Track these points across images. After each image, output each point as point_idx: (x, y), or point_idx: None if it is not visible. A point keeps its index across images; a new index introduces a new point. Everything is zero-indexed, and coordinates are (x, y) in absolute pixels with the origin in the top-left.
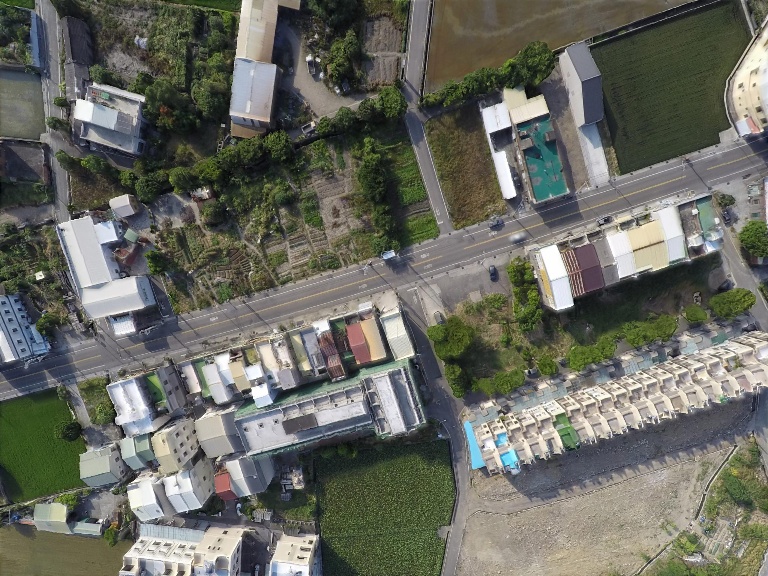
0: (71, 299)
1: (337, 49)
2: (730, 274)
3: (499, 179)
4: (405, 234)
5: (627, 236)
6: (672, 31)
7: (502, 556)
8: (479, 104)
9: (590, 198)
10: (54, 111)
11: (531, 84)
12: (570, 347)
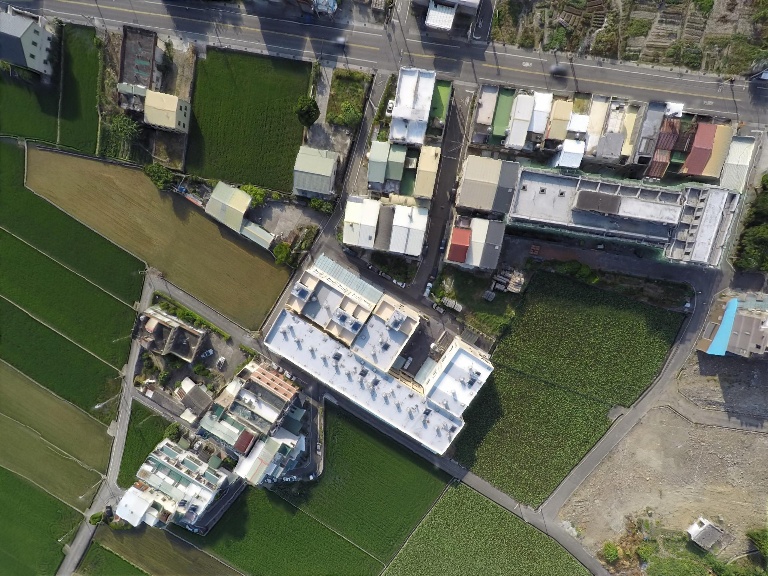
0: None
1: None
2: None
3: None
4: None
5: None
6: None
7: (661, 464)
8: None
9: None
10: None
11: None
12: None
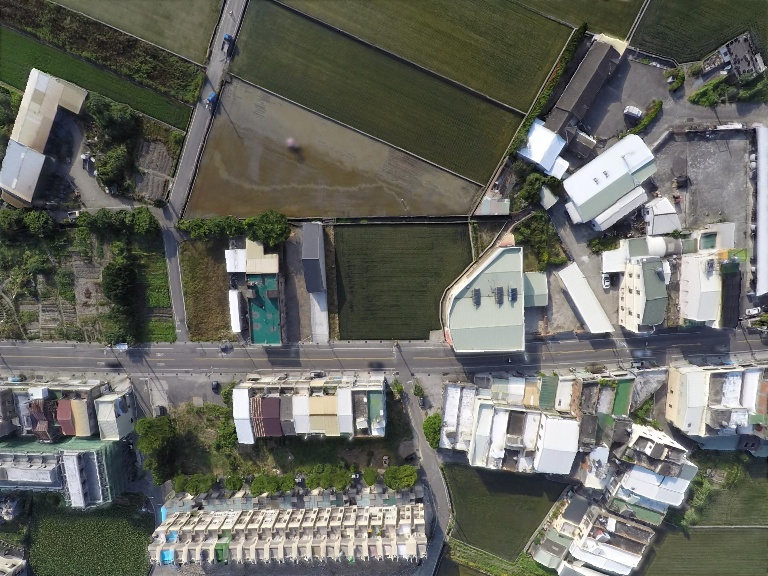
0: None
1: (109, 157)
2: (418, 449)
3: None
4: (145, 331)
5: (307, 401)
6: (407, 234)
7: None
8: (230, 242)
9: (310, 351)
10: None
11: (268, 244)
12: (272, 468)
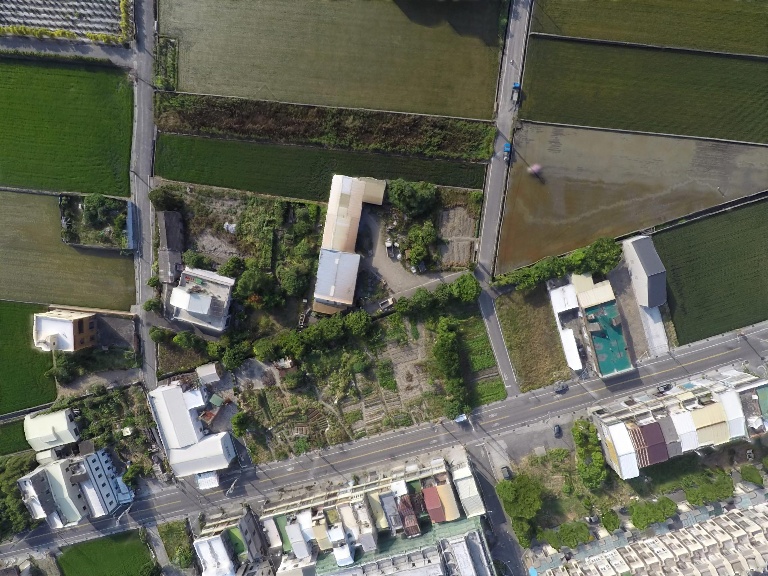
0: (155, 451)
1: (415, 237)
2: None
3: (565, 349)
4: (475, 397)
5: (691, 417)
6: (728, 221)
7: None
8: (547, 283)
9: (650, 366)
10: (145, 286)
11: (598, 272)
12: (629, 497)
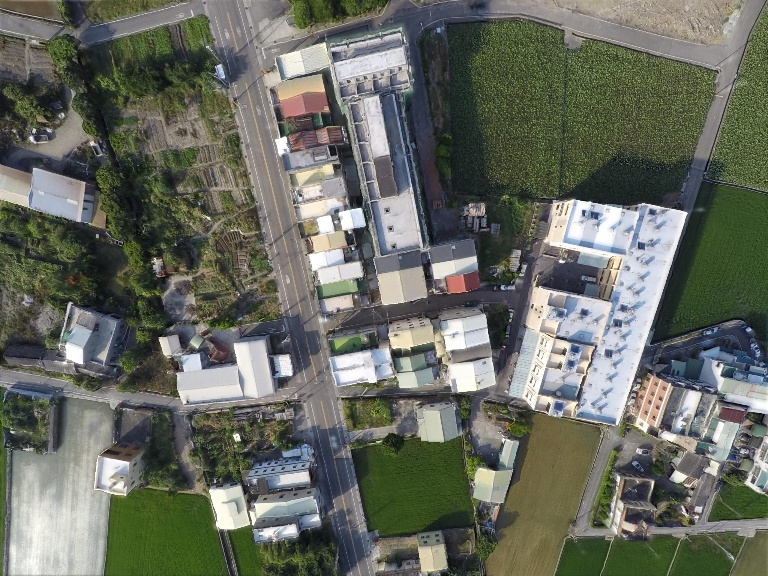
0: (262, 416)
1: (22, 109)
2: None
3: None
4: (203, 55)
5: None
6: None
7: None
8: None
9: None
10: (90, 391)
11: None
12: None
